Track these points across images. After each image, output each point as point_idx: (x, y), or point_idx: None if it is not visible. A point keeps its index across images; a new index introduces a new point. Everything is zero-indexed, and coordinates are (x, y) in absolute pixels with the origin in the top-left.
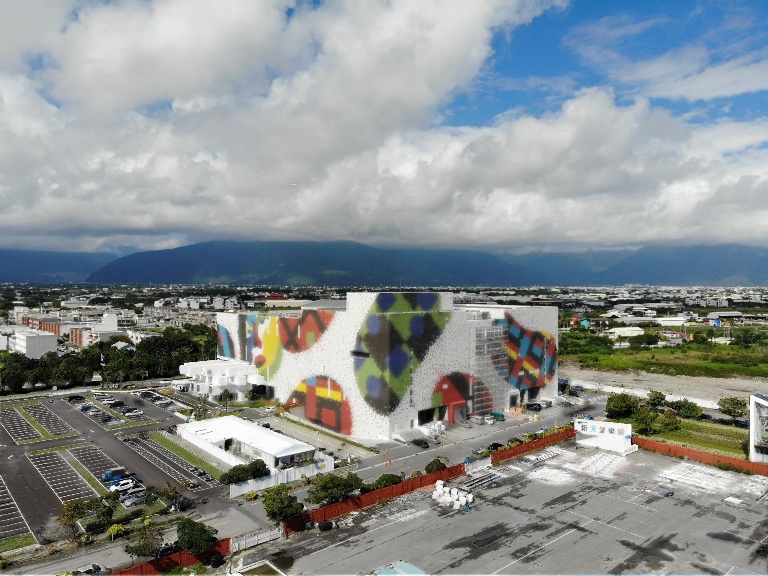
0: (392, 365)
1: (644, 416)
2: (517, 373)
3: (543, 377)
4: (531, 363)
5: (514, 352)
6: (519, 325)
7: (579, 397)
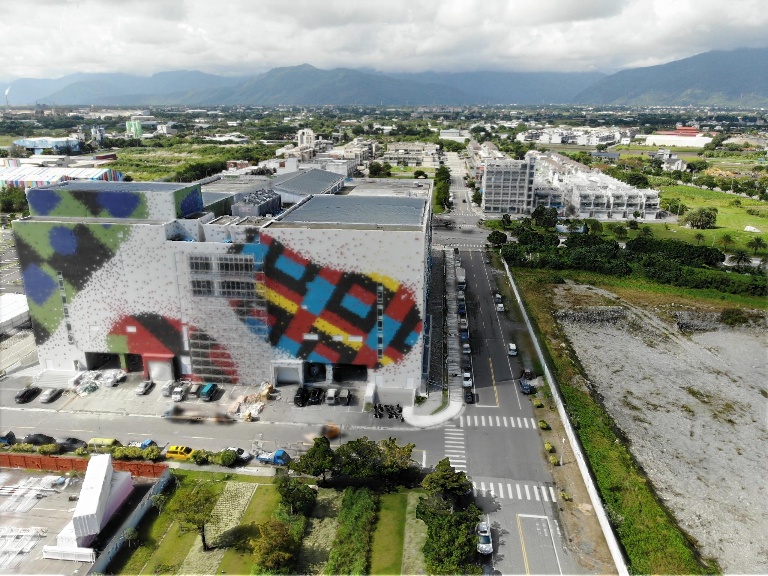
0: (30, 288)
1: (170, 509)
2: (300, 335)
3: (376, 352)
4: (339, 324)
5: (290, 301)
6: (302, 258)
7: (469, 405)
